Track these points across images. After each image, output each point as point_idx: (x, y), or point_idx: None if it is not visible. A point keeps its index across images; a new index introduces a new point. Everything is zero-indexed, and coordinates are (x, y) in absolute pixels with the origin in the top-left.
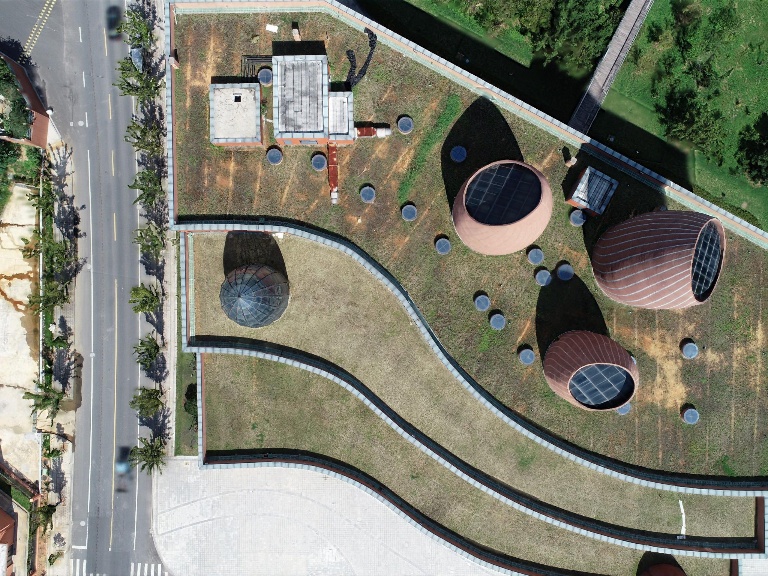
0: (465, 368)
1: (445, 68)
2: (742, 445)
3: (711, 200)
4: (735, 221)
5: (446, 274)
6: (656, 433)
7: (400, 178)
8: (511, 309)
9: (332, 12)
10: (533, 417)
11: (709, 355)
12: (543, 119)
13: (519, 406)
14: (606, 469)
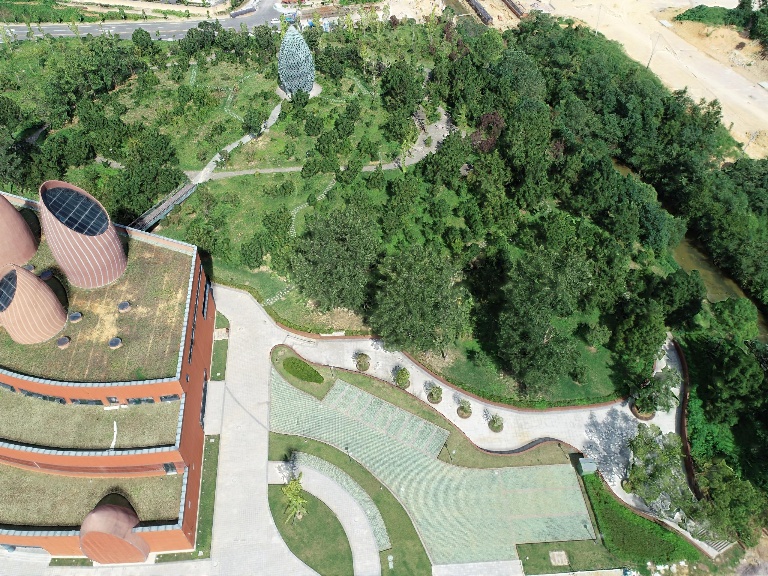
0: None
1: None
2: (155, 359)
3: (222, 282)
4: (165, 239)
5: None
6: (87, 358)
7: None
8: None
9: None
10: None
11: (140, 309)
12: None
13: None
14: (30, 377)
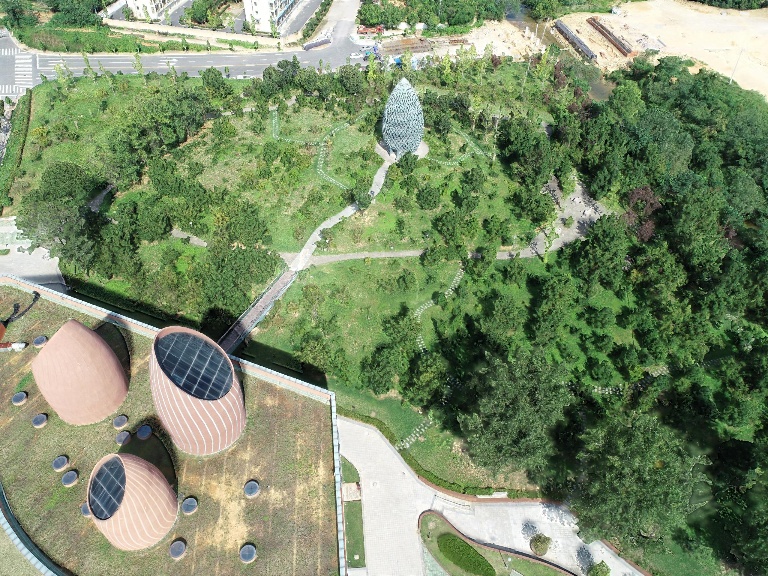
0: (25, 527)
1: (83, 307)
2: None
3: (343, 412)
4: (291, 381)
5: (36, 444)
6: None
7: (23, 376)
8: (88, 468)
9: (14, 285)
10: (82, 573)
11: (272, 493)
12: (147, 329)
13: (70, 562)
14: None
